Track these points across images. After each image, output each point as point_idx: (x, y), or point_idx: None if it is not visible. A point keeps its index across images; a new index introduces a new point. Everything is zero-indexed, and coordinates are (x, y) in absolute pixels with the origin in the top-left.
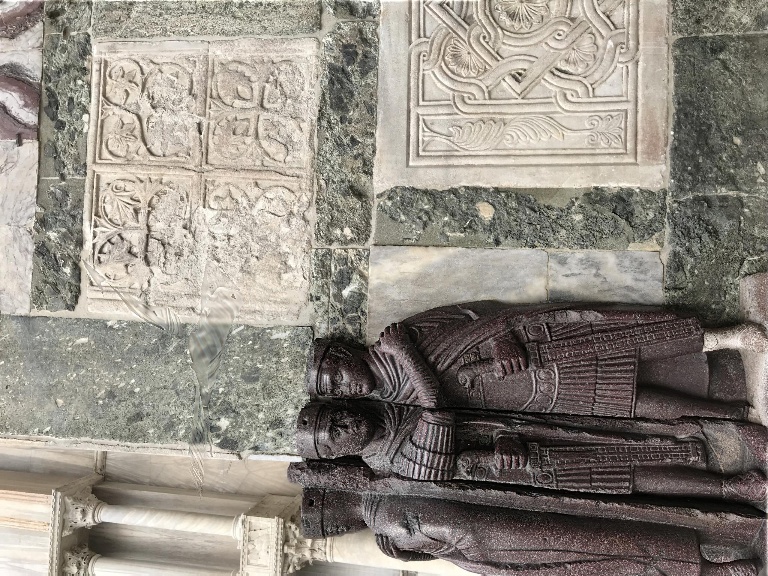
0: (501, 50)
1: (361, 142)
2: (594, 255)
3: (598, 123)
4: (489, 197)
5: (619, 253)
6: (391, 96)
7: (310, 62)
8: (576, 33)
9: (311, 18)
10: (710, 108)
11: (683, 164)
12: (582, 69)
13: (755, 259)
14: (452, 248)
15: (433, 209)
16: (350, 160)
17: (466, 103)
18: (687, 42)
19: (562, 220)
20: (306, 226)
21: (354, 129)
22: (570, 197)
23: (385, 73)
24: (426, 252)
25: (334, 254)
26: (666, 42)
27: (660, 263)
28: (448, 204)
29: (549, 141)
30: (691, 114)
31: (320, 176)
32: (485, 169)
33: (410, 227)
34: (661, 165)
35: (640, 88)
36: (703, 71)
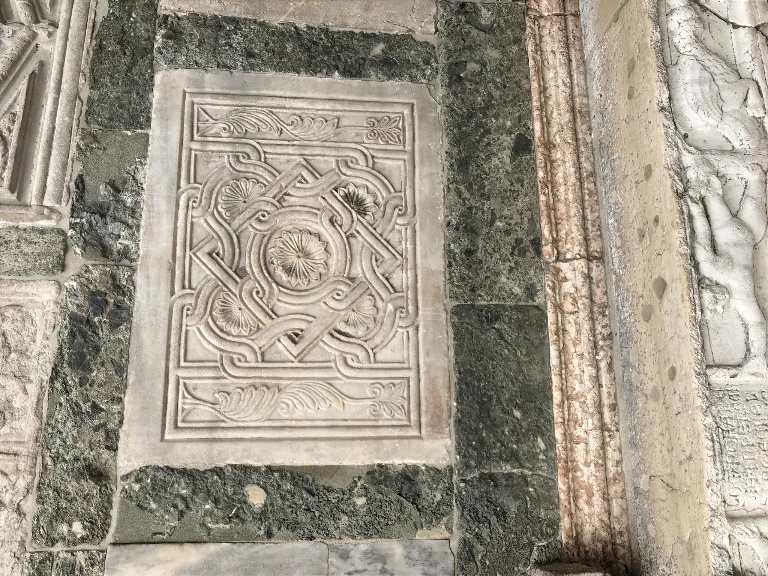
0: (276, 307)
1: (105, 409)
2: (380, 546)
3: (380, 392)
4: (260, 478)
5: (407, 543)
6: (146, 354)
7: (46, 308)
8: (355, 294)
9: (52, 258)
10: (490, 379)
11: (467, 438)
12: (362, 332)
13: (544, 545)
14: (214, 544)
15: (192, 494)
16: (88, 432)
17: (235, 365)
18: (464, 309)
19: (344, 504)
20: (21, 521)
21: (96, 393)
22: (352, 476)
23: (140, 327)
24: (180, 551)
25: (57, 558)
26: (444, 308)
27: (450, 553)
28: (210, 488)
29: (328, 411)
30: (472, 384)
31: (47, 452)
32: (256, 444)
33: (162, 518)
34: (446, 439)
35: (421, 355)
36: (481, 340)
